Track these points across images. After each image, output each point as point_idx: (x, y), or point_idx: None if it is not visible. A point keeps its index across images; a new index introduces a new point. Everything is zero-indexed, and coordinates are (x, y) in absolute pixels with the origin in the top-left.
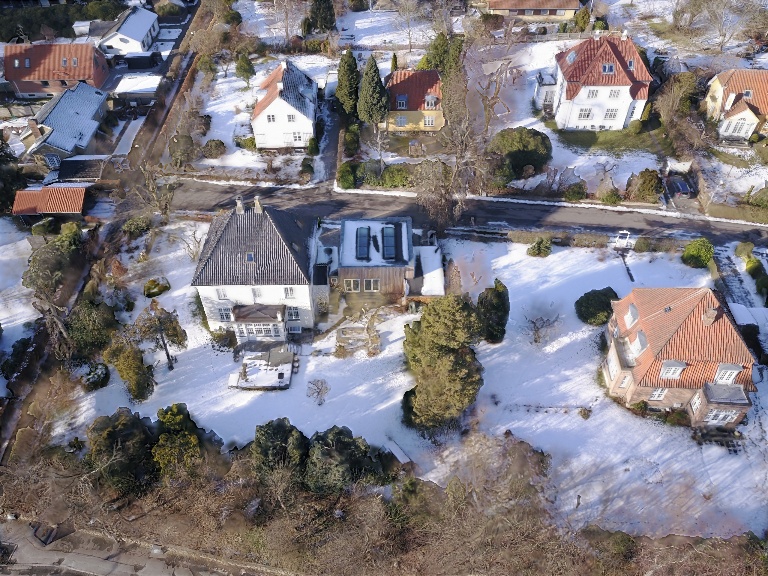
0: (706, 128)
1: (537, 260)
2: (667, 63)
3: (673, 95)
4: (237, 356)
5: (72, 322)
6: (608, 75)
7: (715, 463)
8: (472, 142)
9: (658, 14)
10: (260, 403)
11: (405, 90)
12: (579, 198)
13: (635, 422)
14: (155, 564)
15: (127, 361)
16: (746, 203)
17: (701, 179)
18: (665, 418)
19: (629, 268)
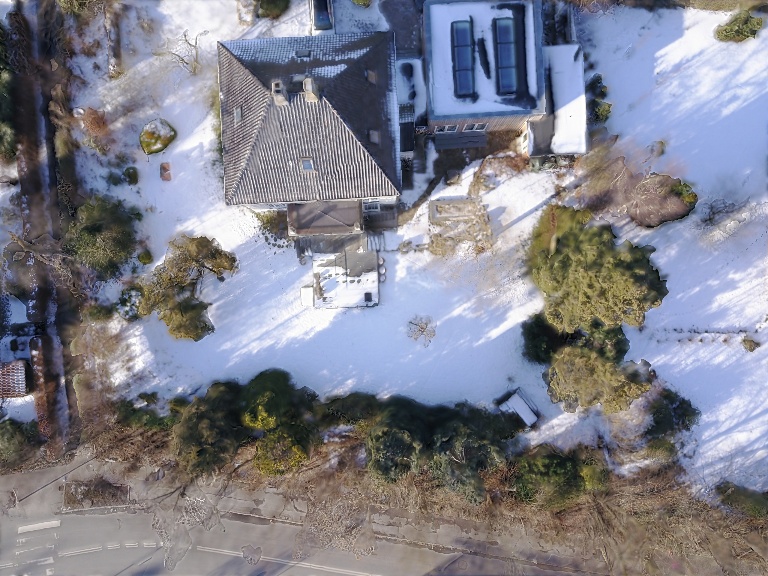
0: None
1: (727, 49)
2: None
3: None
4: (302, 256)
5: (73, 247)
6: None
7: None
8: None
9: None
10: (346, 326)
11: None
12: None
13: None
14: (273, 499)
15: (179, 334)
16: None
17: None
18: None
19: None
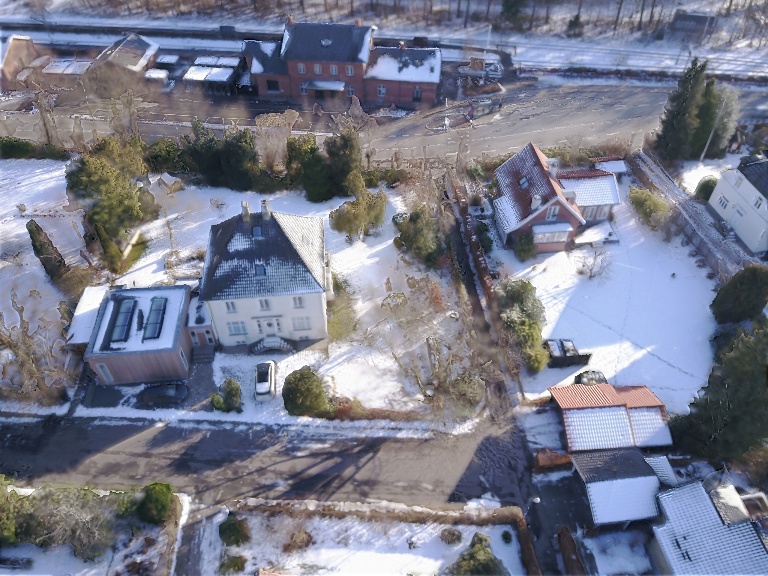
0: None
1: None
2: None
3: None
4: None
5: None
6: None
7: None
8: None
9: None
10: None
11: None
12: None
13: None
14: None
15: None
16: None
17: None
18: None
19: None
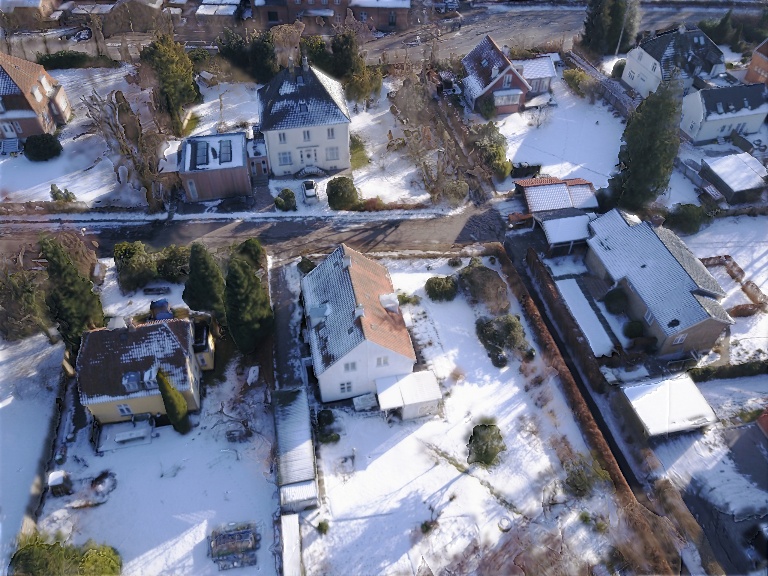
0: None
1: None
2: None
3: None
4: None
5: None
6: None
7: None
8: None
9: None
10: None
11: None
12: None
13: None
14: None
15: None
16: None
17: None
18: None
19: None
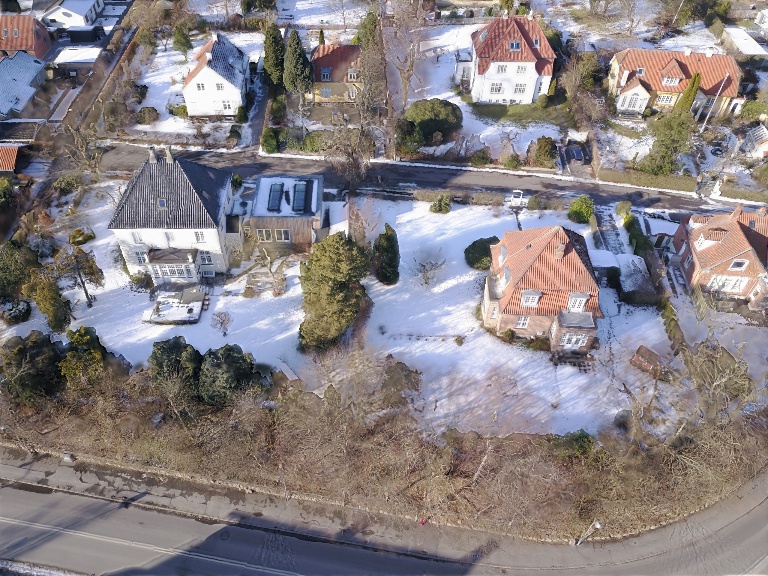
0: (605, 103)
1: (438, 216)
2: (571, 43)
3: (575, 72)
4: (153, 296)
5: None
6: (515, 52)
7: (566, 379)
8: (373, 104)
9: (579, 1)
10: (170, 335)
11: (329, 63)
12: (484, 163)
13: (502, 347)
14: (64, 470)
15: (43, 292)
16: (632, 168)
17: (594, 147)
18: (529, 344)
19: (520, 223)
